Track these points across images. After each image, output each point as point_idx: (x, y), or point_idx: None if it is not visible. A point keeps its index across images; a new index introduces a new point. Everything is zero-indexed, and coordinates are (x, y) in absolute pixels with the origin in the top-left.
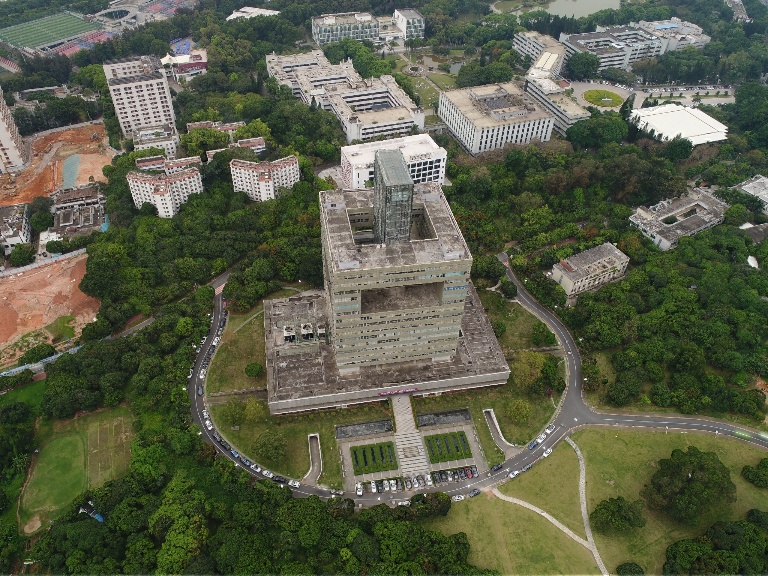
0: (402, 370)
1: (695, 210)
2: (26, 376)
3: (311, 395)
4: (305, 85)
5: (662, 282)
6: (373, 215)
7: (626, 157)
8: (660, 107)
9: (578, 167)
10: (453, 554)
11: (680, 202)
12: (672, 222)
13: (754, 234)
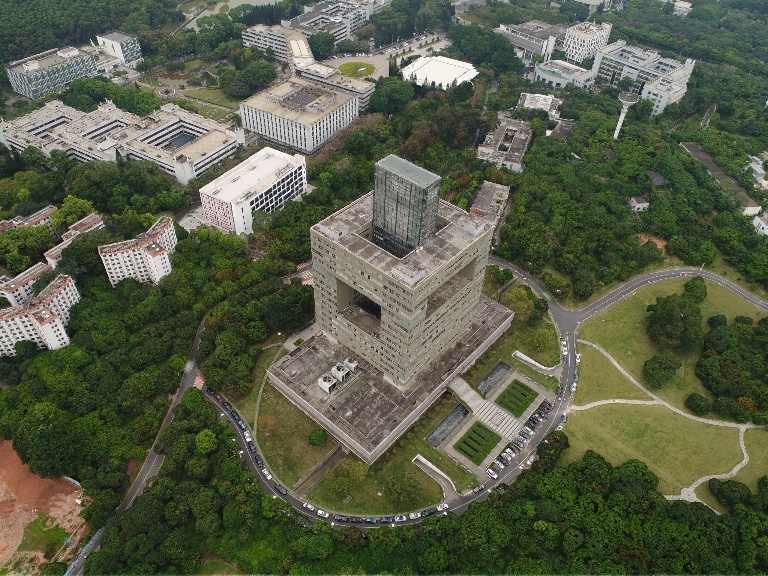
0: (444, 358)
1: (508, 134)
2: None
3: (398, 423)
4: (80, 142)
5: (543, 195)
6: (372, 228)
7: (443, 109)
8: (415, 63)
9: (417, 130)
10: (604, 468)
11: (497, 132)
12: (505, 149)
13: (558, 137)
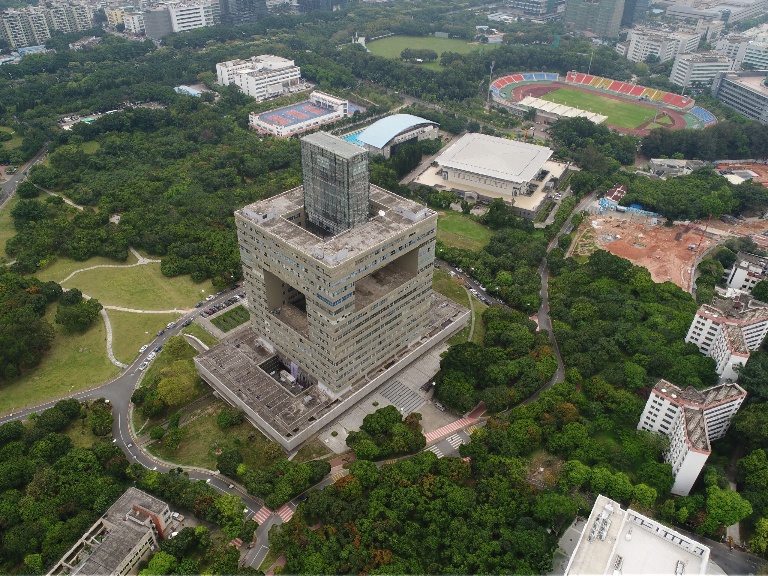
0: None
1: None
2: (547, 231)
3: None
4: None
5: None
6: None
7: None
8: None
9: None
10: None
11: None
12: None
13: None
